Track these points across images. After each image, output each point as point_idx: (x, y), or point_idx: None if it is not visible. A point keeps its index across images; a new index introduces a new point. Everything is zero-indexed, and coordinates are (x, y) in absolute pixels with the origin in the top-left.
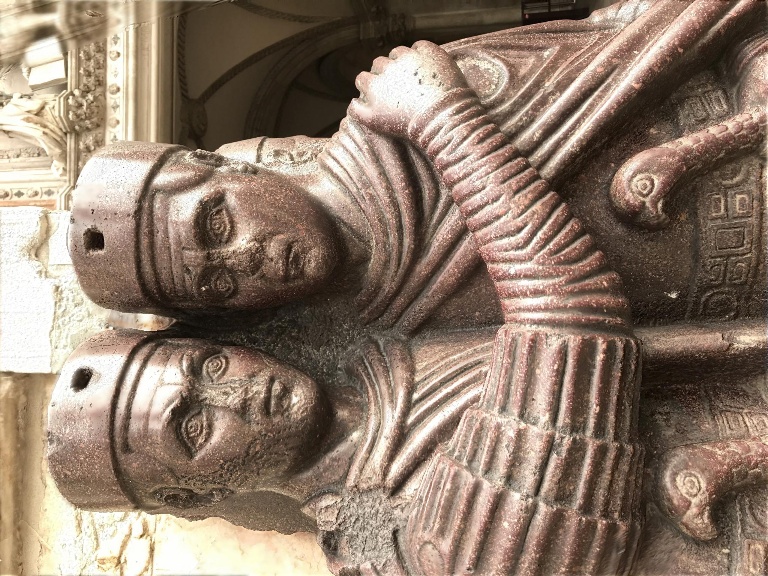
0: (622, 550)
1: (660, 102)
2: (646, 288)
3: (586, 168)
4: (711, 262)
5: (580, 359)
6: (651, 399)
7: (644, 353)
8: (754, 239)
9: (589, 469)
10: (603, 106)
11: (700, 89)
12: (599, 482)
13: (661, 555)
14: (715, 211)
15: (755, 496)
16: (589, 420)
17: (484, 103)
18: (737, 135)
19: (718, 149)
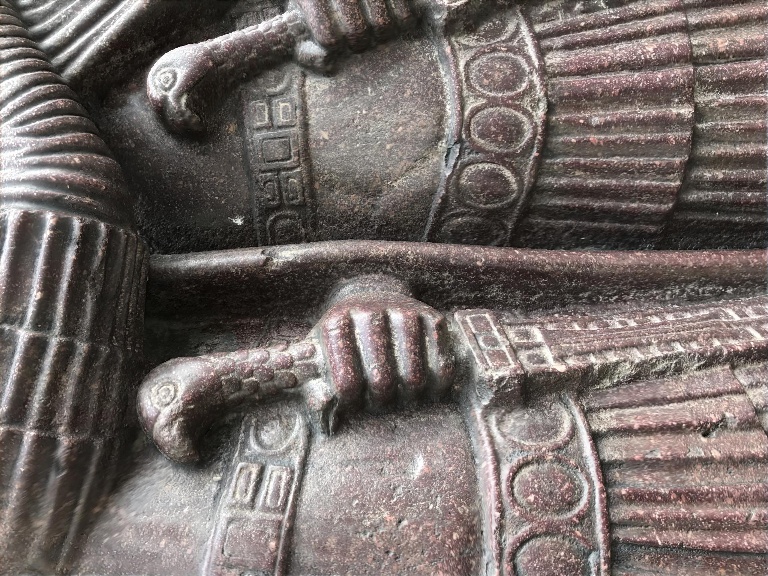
0: (62, 473)
1: (219, 15)
2: (208, 212)
3: (137, 77)
4: (262, 177)
5: (20, 235)
6: (206, 333)
7: (175, 269)
8: (301, 151)
9: (16, 367)
10: (137, 1)
11: (260, 5)
12: (35, 386)
13: (140, 489)
14: (260, 120)
15: (264, 416)
16: (28, 309)
17: (24, 1)
18: (266, 33)
19: (247, 47)
